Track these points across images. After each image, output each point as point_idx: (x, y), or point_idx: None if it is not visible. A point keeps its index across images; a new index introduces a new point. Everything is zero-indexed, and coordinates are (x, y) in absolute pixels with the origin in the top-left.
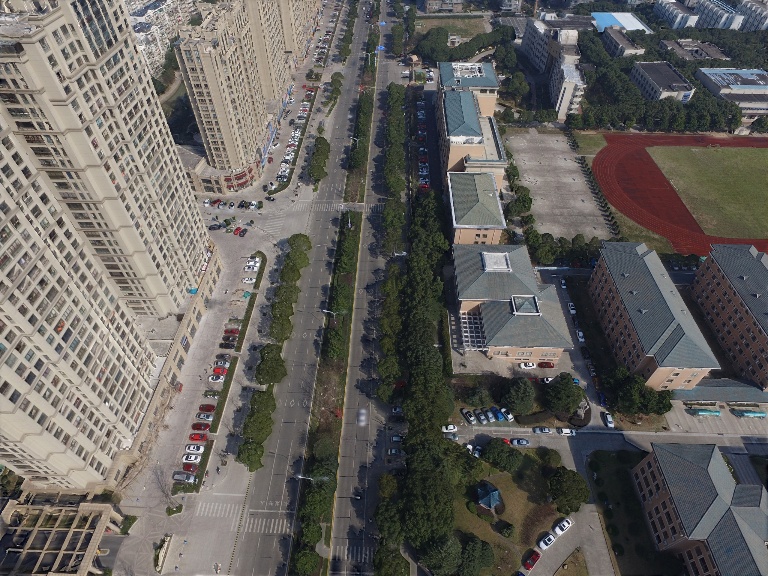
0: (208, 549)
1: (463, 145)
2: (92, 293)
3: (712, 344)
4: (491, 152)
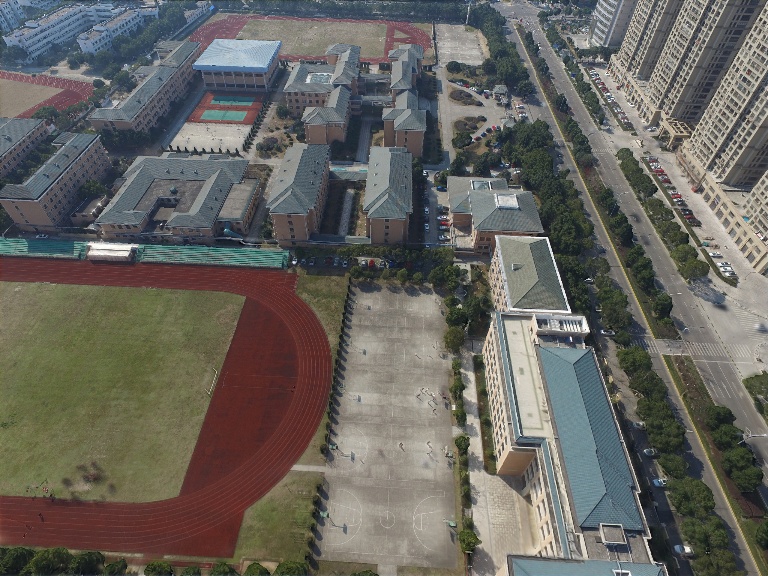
0: (620, 145)
1: (565, 317)
2: (763, 98)
3: (331, 204)
4: (516, 337)
